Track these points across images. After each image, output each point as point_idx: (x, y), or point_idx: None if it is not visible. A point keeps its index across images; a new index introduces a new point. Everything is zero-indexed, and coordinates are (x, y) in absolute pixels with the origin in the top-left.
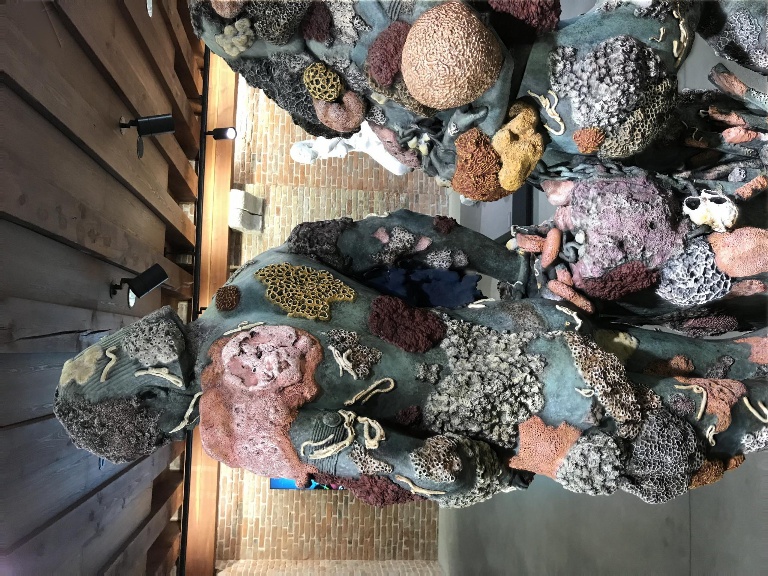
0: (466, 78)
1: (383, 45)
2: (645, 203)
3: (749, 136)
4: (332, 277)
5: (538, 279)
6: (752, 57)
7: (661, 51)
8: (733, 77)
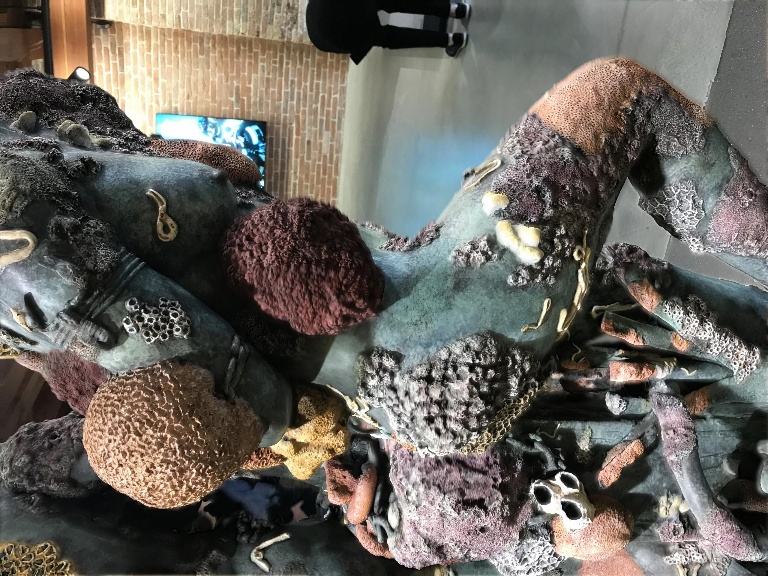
0: (188, 503)
1: (58, 379)
2: (478, 508)
3: (642, 377)
4: (54, 555)
5: (345, 515)
6: (682, 238)
7: (537, 340)
8: (645, 288)
